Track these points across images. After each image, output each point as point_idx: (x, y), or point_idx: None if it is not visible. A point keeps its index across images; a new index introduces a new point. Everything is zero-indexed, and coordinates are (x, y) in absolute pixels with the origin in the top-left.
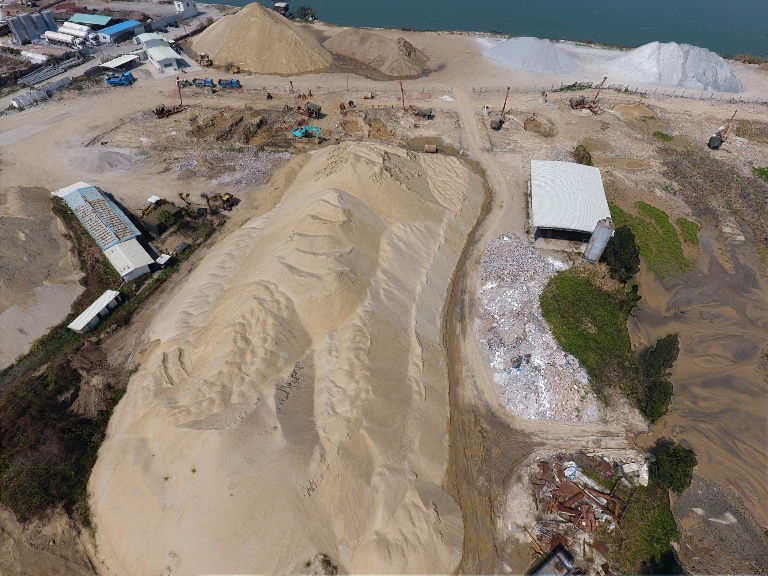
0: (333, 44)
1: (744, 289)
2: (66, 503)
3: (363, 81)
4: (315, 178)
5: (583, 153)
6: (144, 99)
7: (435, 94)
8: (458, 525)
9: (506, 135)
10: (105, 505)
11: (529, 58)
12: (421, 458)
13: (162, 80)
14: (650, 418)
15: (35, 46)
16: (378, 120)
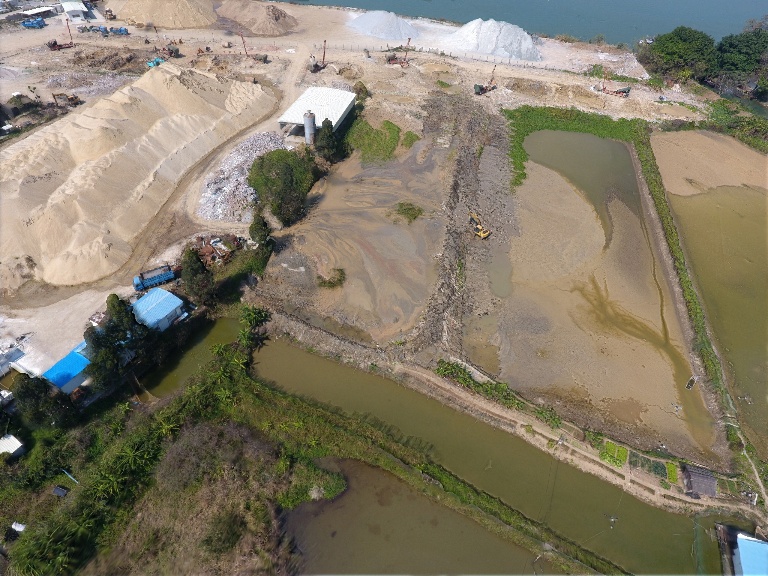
0: (222, 9)
1: (419, 172)
2: None
3: (231, 36)
4: None
5: (359, 87)
6: (47, 38)
7: (283, 48)
8: (124, 256)
9: (319, 76)
10: None
11: (377, 27)
12: (117, 225)
13: None
14: (280, 219)
15: None
16: (226, 62)
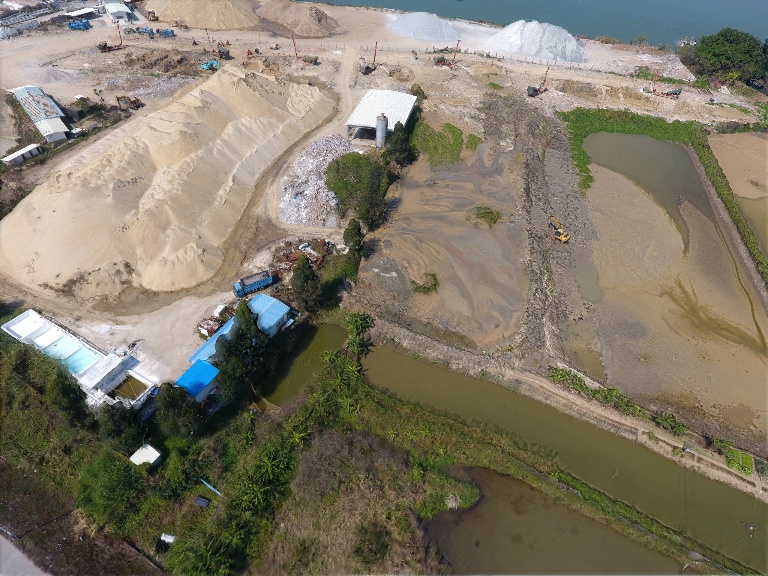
0: (262, 10)
1: (489, 175)
2: None
3: (276, 38)
4: None
5: (416, 89)
6: (95, 40)
7: (330, 49)
8: (218, 262)
9: (371, 78)
10: (3, 234)
11: (419, 29)
12: (206, 230)
13: (113, 28)
14: None
15: None
16: (276, 64)
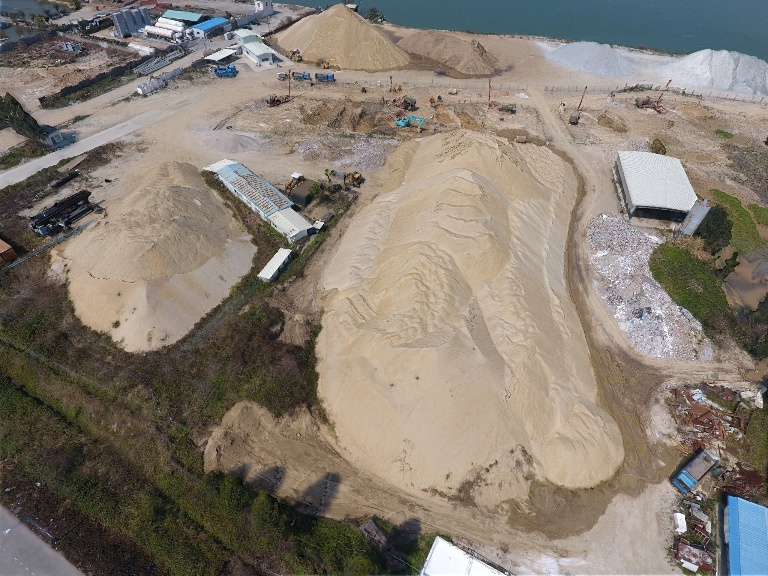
0: (408, 44)
1: None
2: (307, 405)
3: (443, 78)
4: (438, 160)
5: (660, 146)
6: (251, 90)
7: (511, 92)
8: (617, 431)
9: (584, 129)
10: (340, 406)
11: (591, 61)
12: (579, 381)
13: (261, 73)
14: (758, 358)
15: (136, 39)
16: (465, 113)
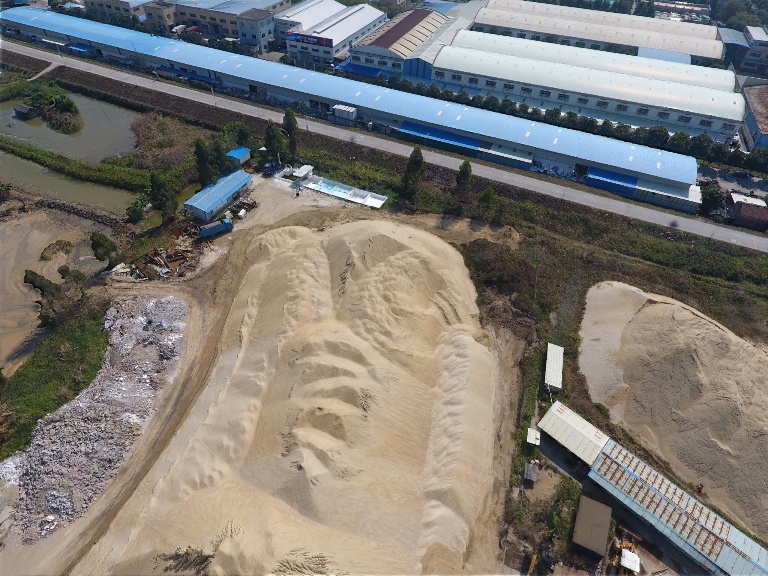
0: None
1: None
2: (466, 246)
3: None
4: None
5: None
6: None
7: None
8: None
9: None
10: None
11: None
12: None
13: None
14: None
15: None
16: None
